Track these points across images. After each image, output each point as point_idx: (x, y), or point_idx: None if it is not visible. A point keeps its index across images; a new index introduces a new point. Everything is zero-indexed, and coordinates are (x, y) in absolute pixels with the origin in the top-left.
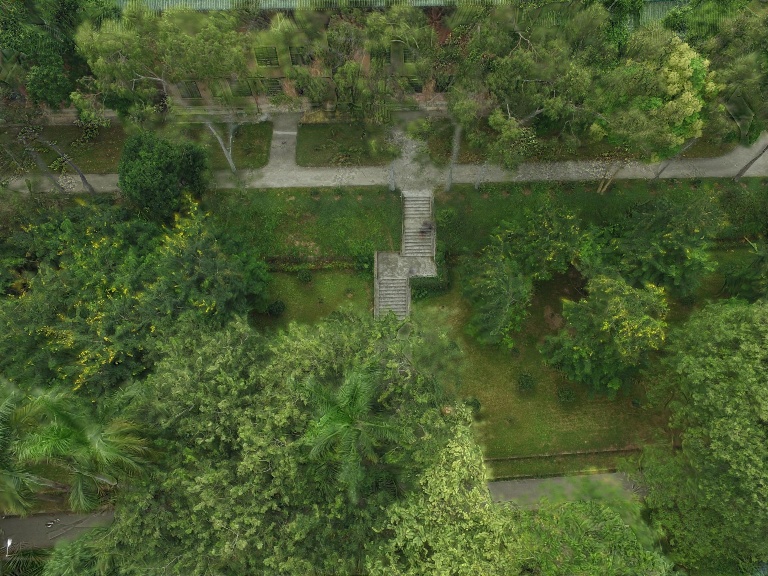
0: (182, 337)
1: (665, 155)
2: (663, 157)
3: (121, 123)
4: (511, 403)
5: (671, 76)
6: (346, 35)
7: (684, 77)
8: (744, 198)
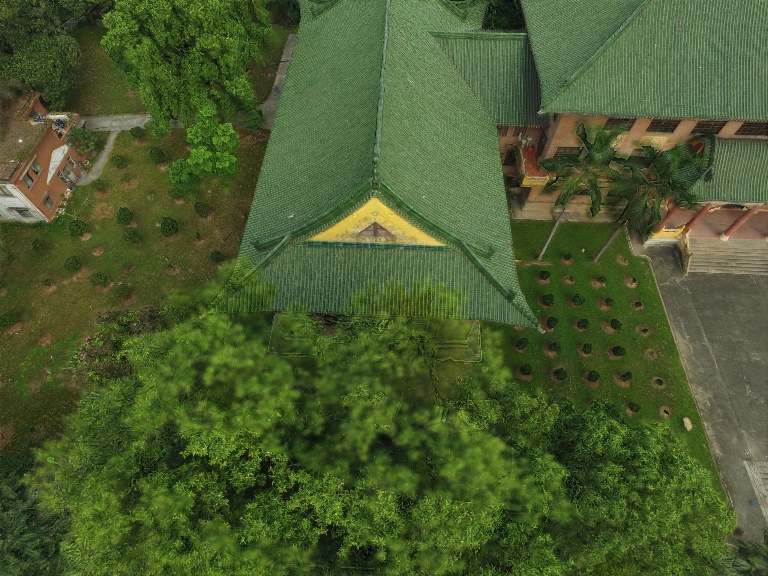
0: None
1: None
2: None
3: None
4: None
5: None
6: None
7: None
8: None
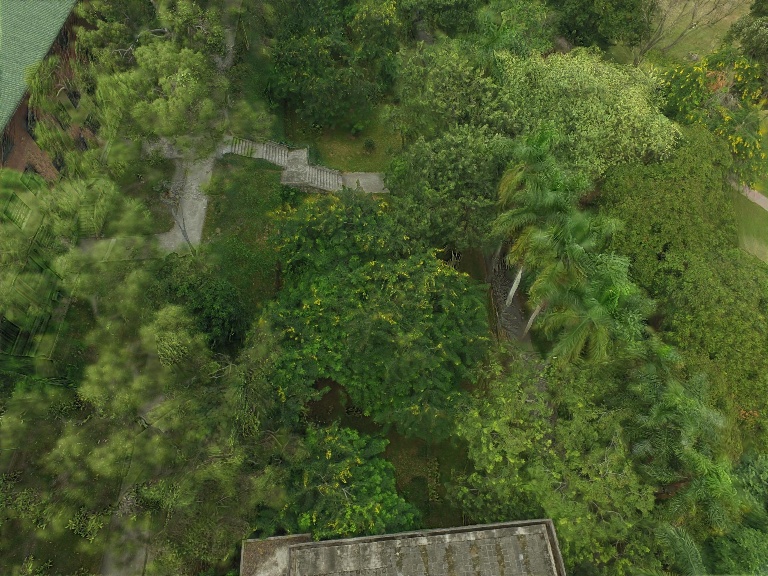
0: None
1: None
2: None
3: (20, 452)
4: None
5: None
6: None
7: None
8: None
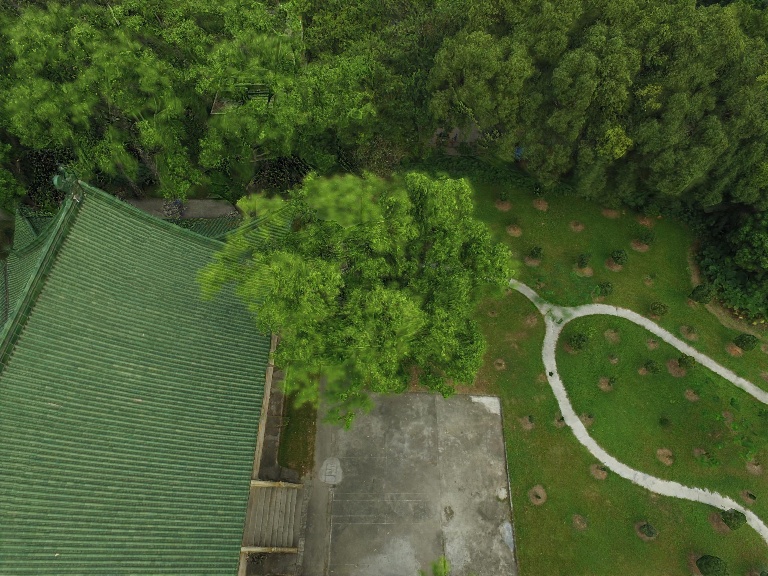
0: (27, 25)
1: None
2: None
3: None
4: None
5: None
6: None
7: None
8: None
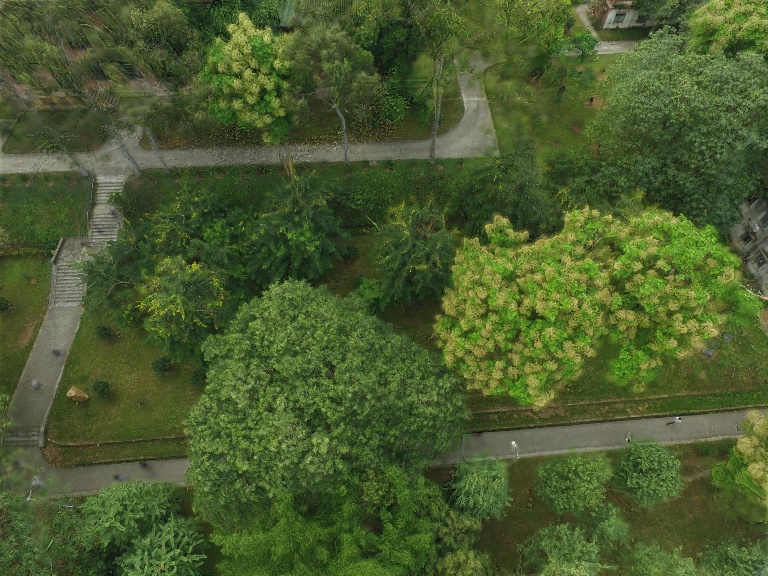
0: None
1: (276, 135)
2: (277, 137)
3: None
4: (150, 386)
5: (232, 53)
6: (29, 20)
7: (246, 54)
8: (438, 180)
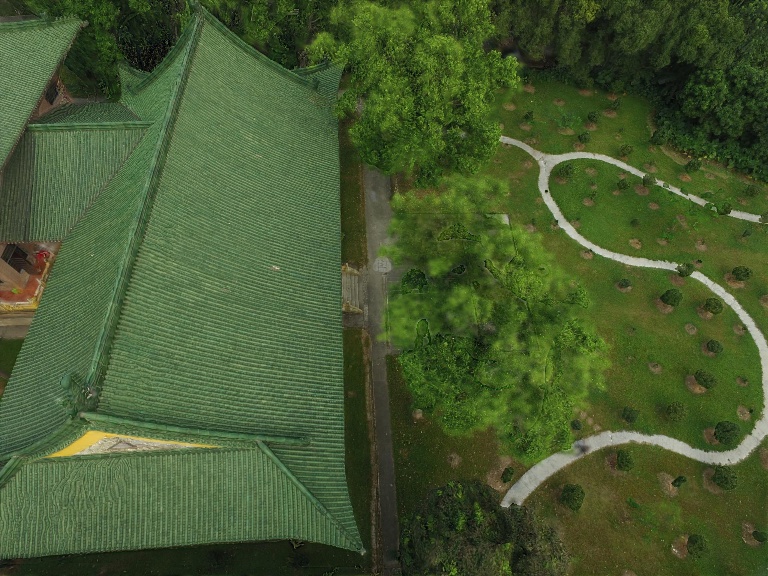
0: None
1: None
2: None
3: None
4: None
5: None
6: None
7: None
8: None
